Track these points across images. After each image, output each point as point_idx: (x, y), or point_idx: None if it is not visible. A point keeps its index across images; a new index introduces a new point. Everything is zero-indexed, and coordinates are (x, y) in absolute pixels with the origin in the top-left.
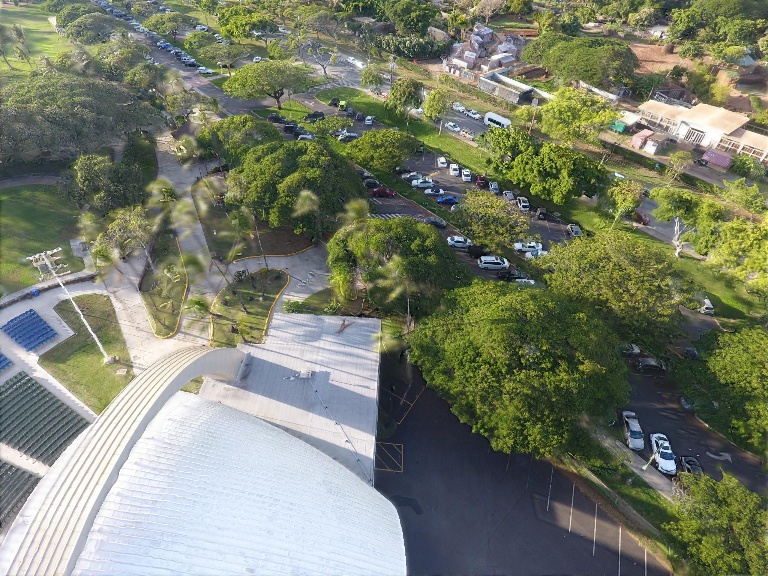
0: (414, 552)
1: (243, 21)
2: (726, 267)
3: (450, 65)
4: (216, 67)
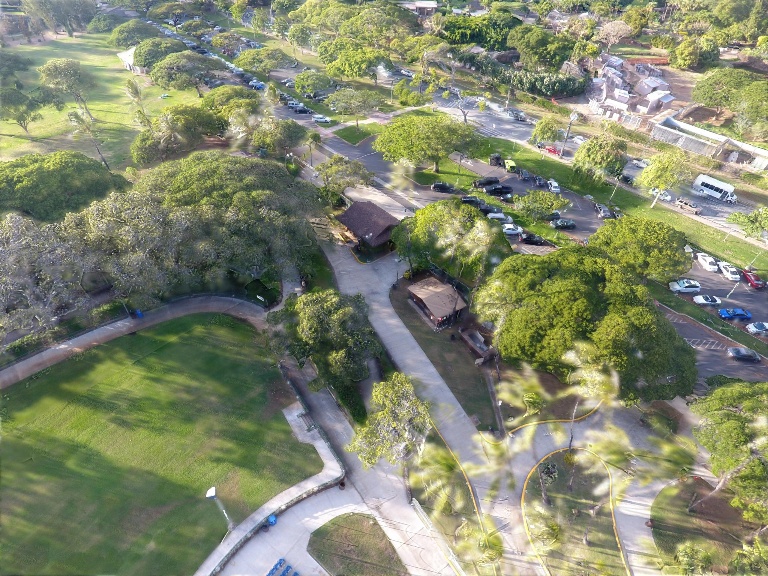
0: None
1: (358, 58)
2: None
3: (605, 107)
4: (331, 113)
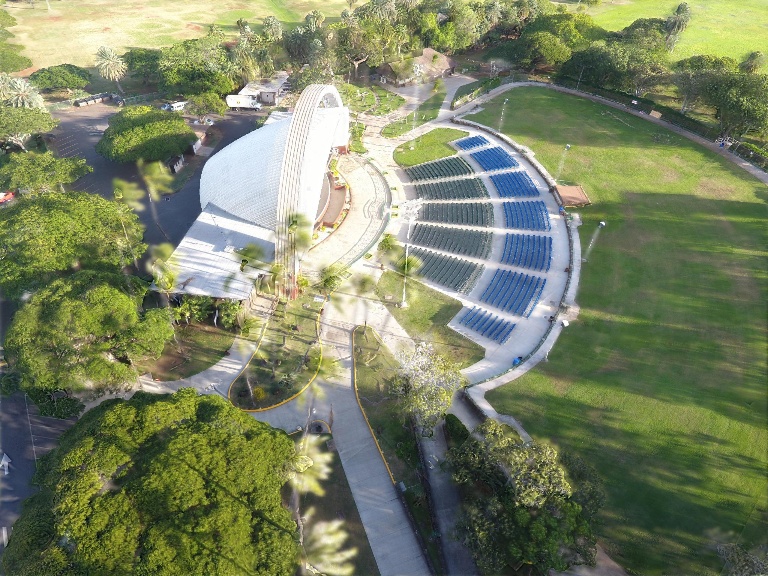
0: None
1: None
2: None
3: None
4: None
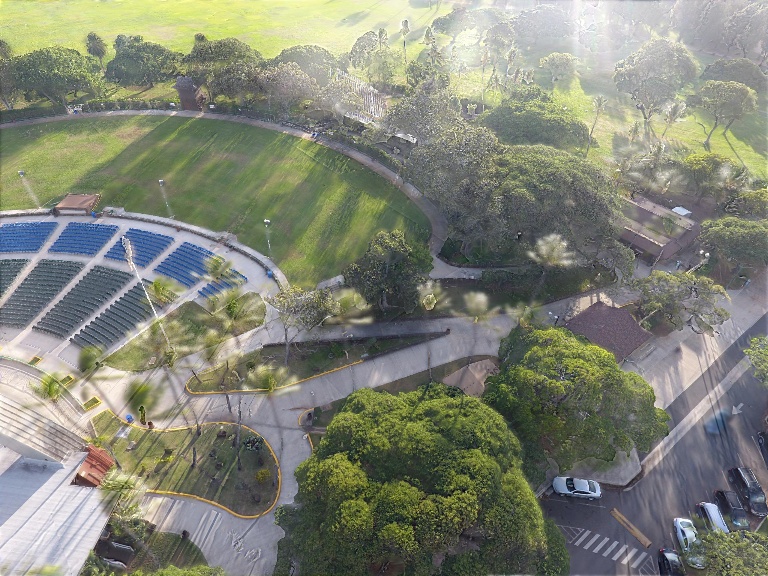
0: None
1: None
2: None
3: None
4: None
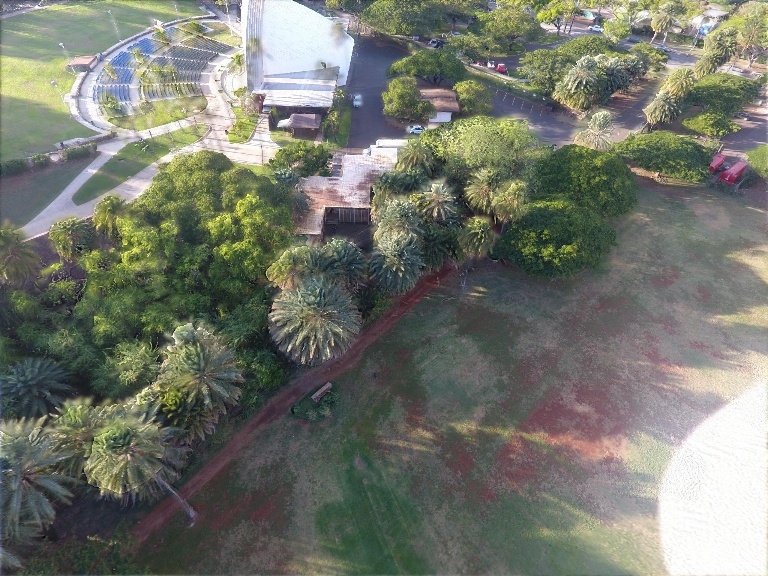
0: (360, 67)
1: None
2: (506, 2)
3: None
4: None
